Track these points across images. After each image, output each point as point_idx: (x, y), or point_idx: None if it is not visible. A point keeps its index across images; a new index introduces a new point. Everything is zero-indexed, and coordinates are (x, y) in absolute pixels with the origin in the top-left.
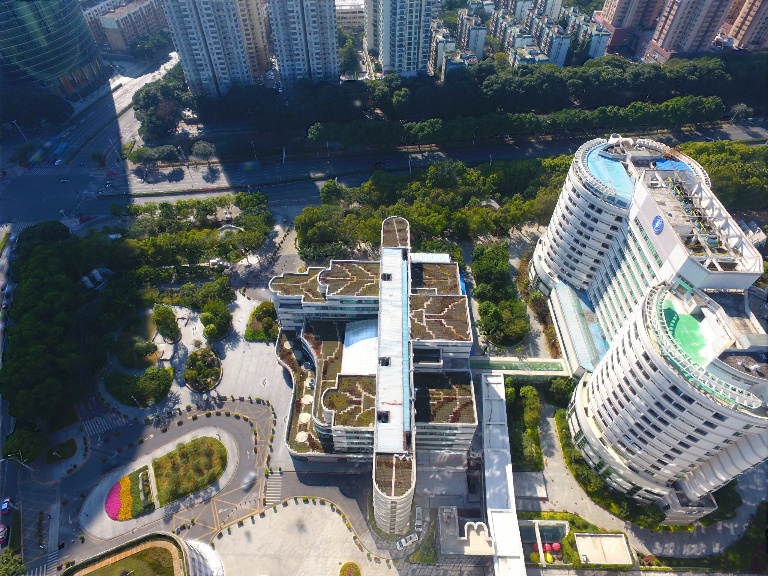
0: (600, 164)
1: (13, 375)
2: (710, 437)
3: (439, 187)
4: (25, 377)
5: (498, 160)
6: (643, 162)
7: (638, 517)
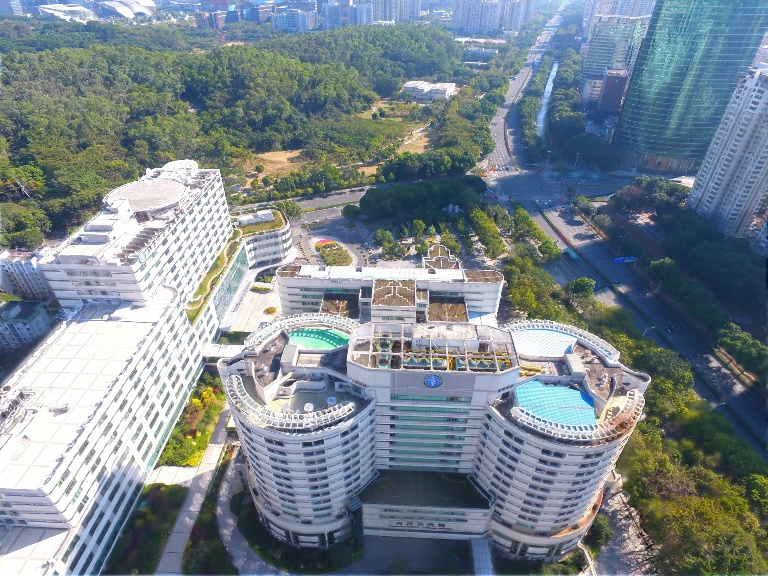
0: (554, 340)
1: None
2: None
3: (635, 361)
4: (373, 192)
5: (767, 447)
6: (565, 369)
7: None
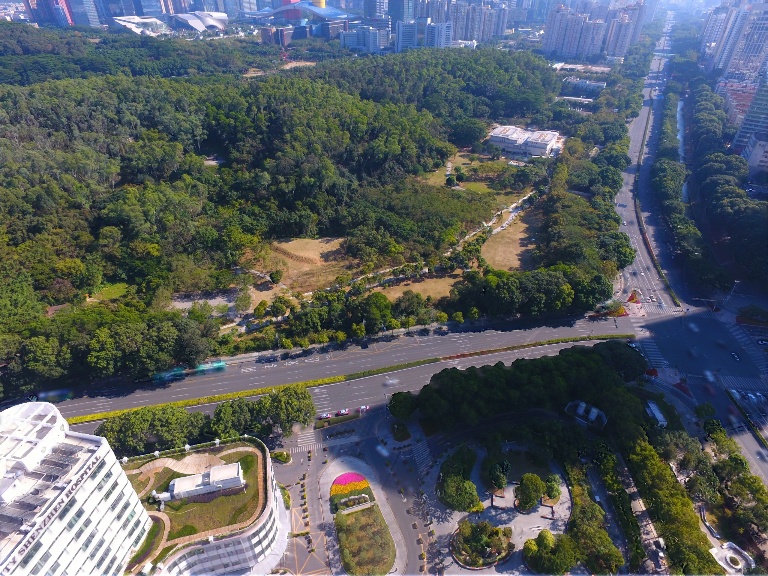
0: None
1: (446, 377)
2: None
3: None
4: (445, 385)
5: None
6: None
7: None
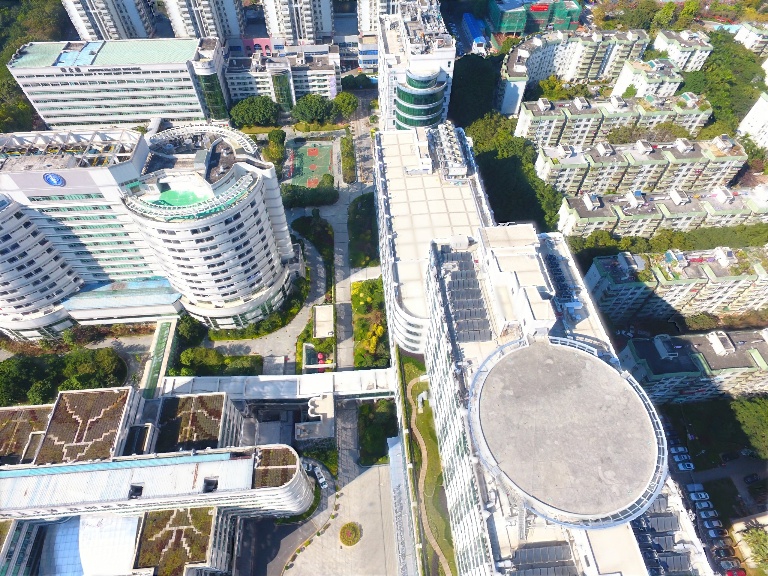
0: None
1: None
2: (263, 219)
3: None
4: None
5: None
6: None
7: (302, 295)
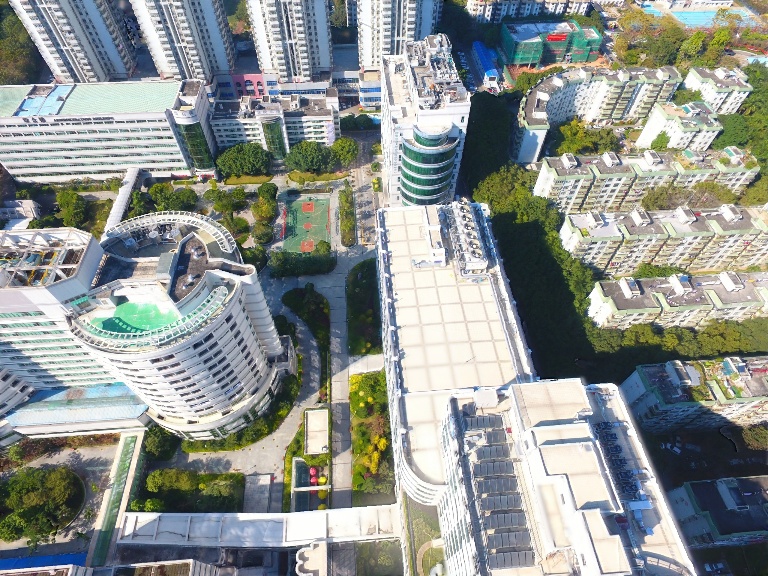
0: None
1: None
2: (242, 329)
3: None
4: None
5: None
6: None
7: (292, 396)
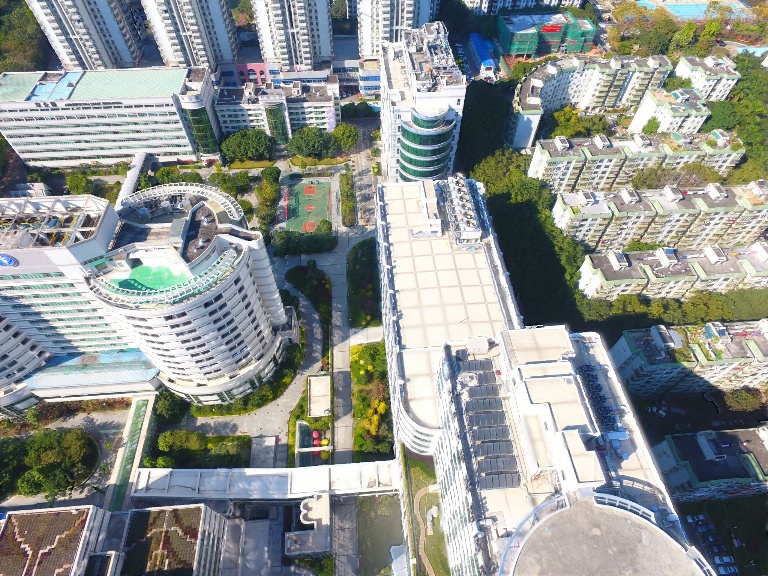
0: None
1: None
2: (249, 293)
3: None
4: None
5: None
6: None
7: (296, 363)
